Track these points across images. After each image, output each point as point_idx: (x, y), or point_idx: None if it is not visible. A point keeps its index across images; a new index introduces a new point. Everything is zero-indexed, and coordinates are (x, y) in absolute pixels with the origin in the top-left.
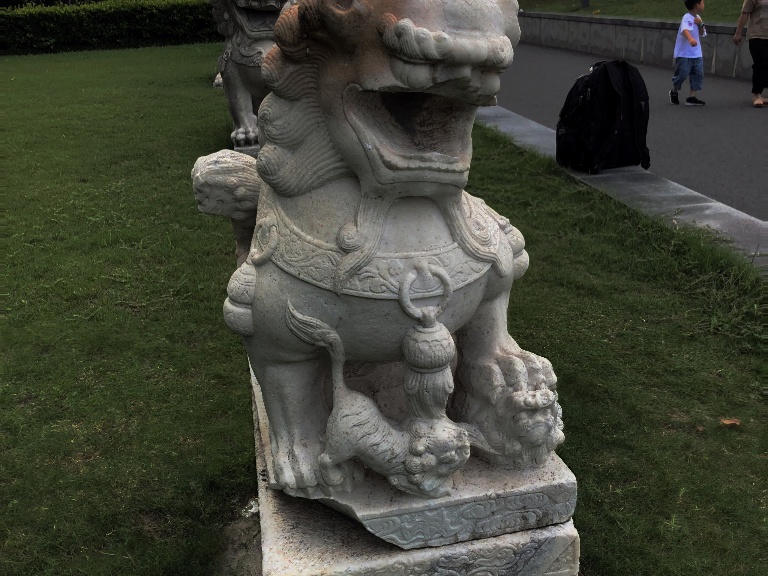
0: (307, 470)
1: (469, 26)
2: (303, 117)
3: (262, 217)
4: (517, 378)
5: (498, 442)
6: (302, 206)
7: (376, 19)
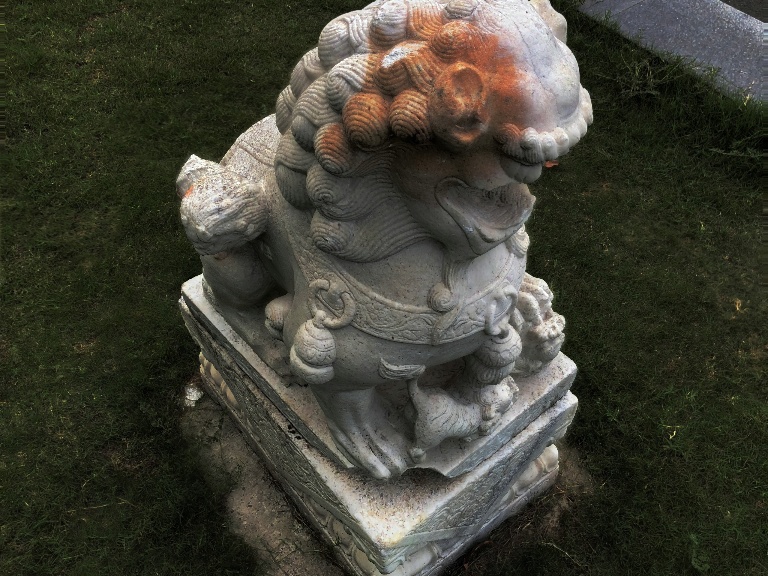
0: (400, 462)
1: (574, 108)
2: (370, 193)
3: (318, 277)
4: (535, 315)
5: (522, 365)
6: (378, 273)
7: (493, 129)
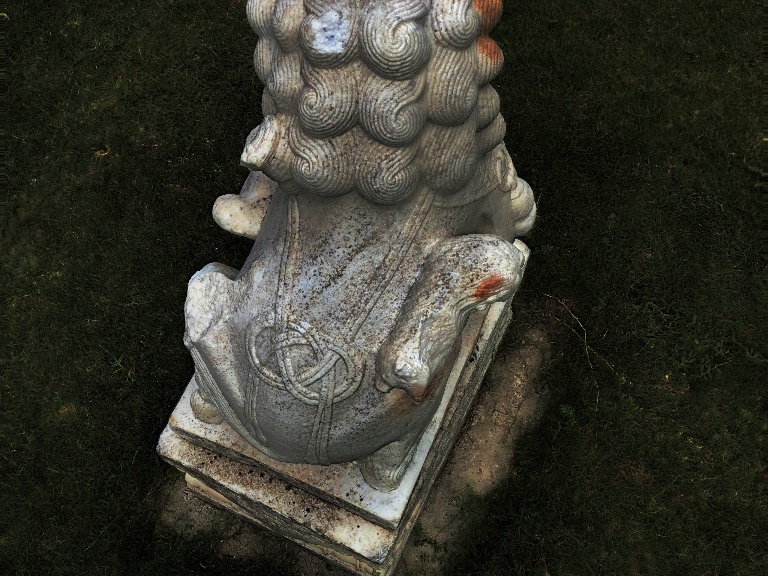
0: None
1: None
2: None
3: (496, 171)
4: None
5: None
6: None
7: None
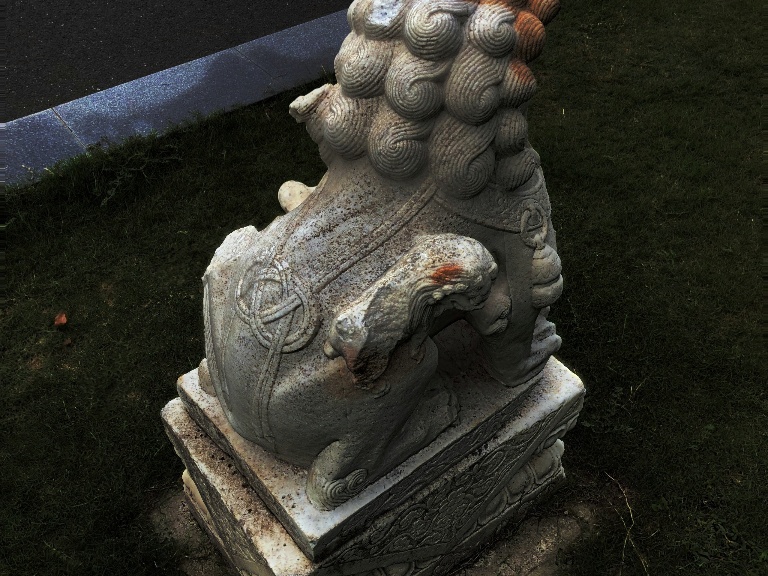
0: None
1: None
2: None
3: (521, 217)
4: None
5: None
6: None
7: None
